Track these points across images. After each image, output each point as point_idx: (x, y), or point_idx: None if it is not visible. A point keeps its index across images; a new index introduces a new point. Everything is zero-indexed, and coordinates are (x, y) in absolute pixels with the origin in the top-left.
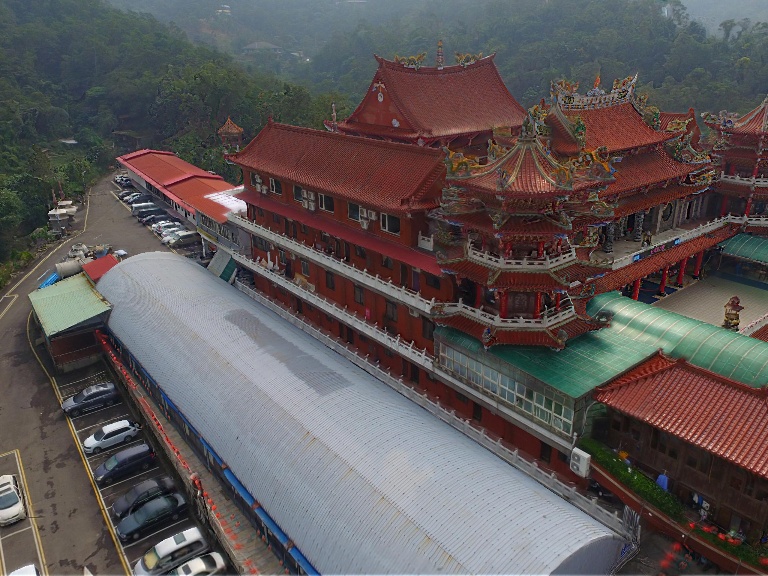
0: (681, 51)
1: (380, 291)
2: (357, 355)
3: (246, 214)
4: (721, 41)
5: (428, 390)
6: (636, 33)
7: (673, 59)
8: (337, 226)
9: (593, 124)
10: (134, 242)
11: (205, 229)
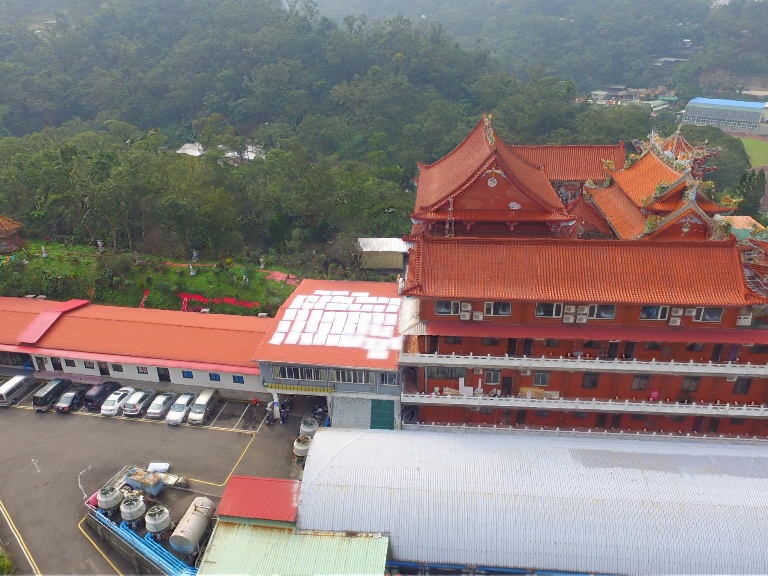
0: (344, 48)
1: (715, 373)
2: (657, 435)
3: (403, 347)
4: (348, 34)
5: (732, 432)
6: (287, 30)
7: (335, 55)
8: (629, 330)
9: None
10: (123, 444)
11: (291, 383)
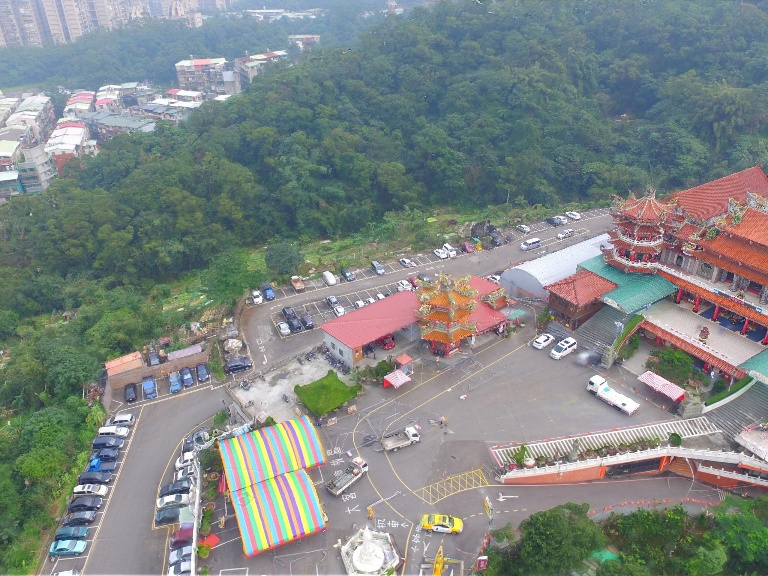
0: None
1: None
2: None
3: None
4: None
5: None
6: None
7: None
8: None
9: (765, 225)
10: None
11: None
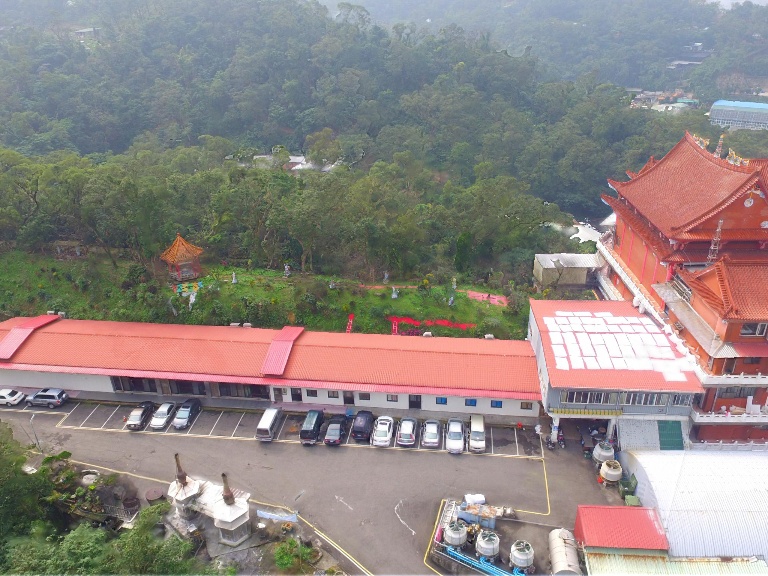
0: (406, 58)
1: None
2: None
3: None
4: None
5: None
6: (345, 39)
7: (395, 64)
8: None
9: None
10: (418, 476)
11: (578, 407)
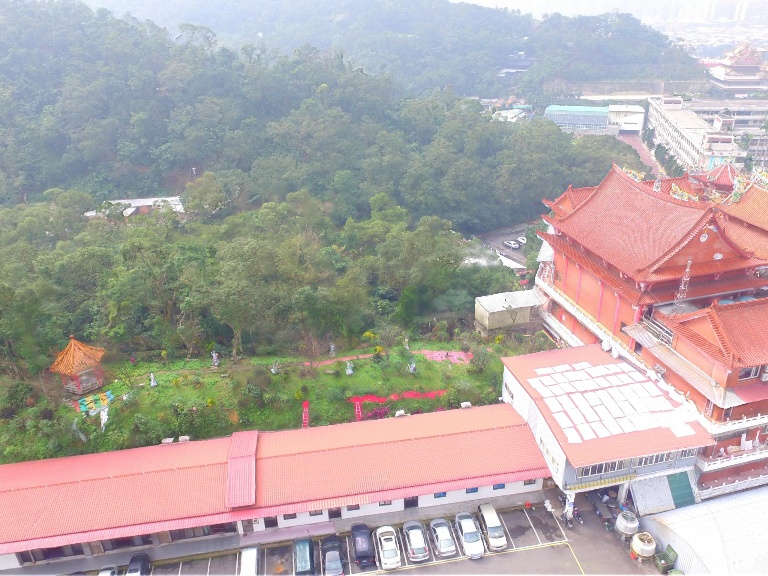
0: (265, 82)
1: None
2: None
3: None
4: None
5: None
6: (193, 64)
7: (253, 89)
8: None
9: None
10: None
11: (594, 479)
